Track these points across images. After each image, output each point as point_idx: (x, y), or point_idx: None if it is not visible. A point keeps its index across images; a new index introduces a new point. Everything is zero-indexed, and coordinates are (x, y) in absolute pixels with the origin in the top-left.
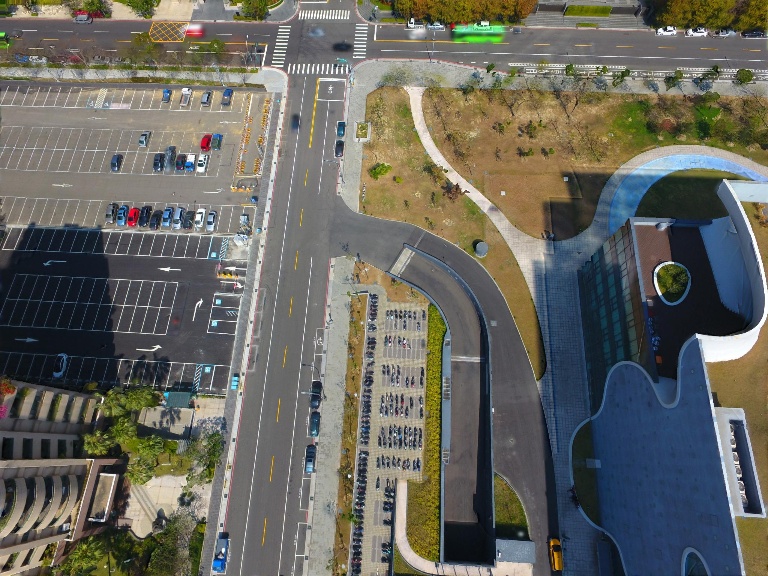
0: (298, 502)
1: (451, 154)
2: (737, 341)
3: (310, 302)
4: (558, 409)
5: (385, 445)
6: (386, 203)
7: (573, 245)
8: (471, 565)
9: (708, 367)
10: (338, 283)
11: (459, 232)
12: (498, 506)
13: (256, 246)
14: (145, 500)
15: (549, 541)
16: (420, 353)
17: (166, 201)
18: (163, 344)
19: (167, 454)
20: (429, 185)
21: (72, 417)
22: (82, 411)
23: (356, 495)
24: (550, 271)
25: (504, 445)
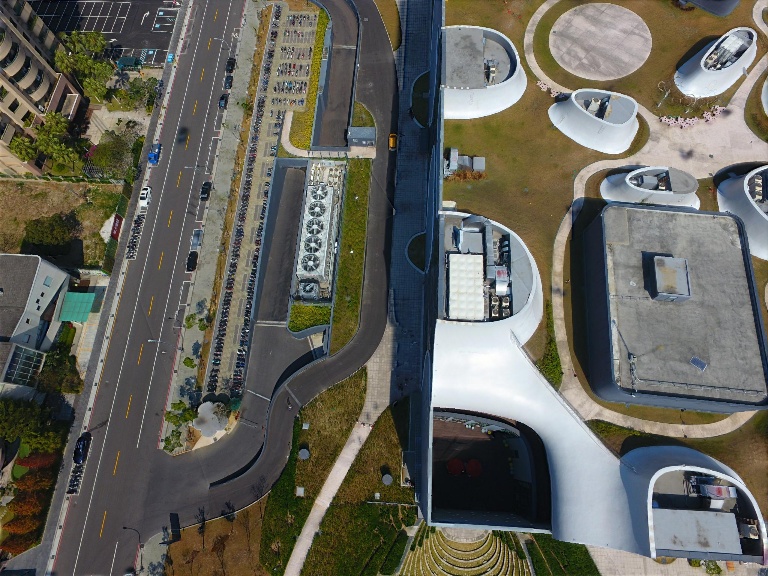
0: (213, 126)
1: None
2: None
3: (231, 12)
4: (407, 66)
5: (278, 90)
6: None
7: None
8: (331, 147)
9: None
10: None
11: None
12: (356, 119)
13: None
14: (101, 125)
15: (389, 135)
16: (310, 40)
17: None
18: (118, 38)
19: (118, 98)
20: None
21: (46, 41)
22: (54, 49)
23: (255, 118)
24: None
25: (365, 87)
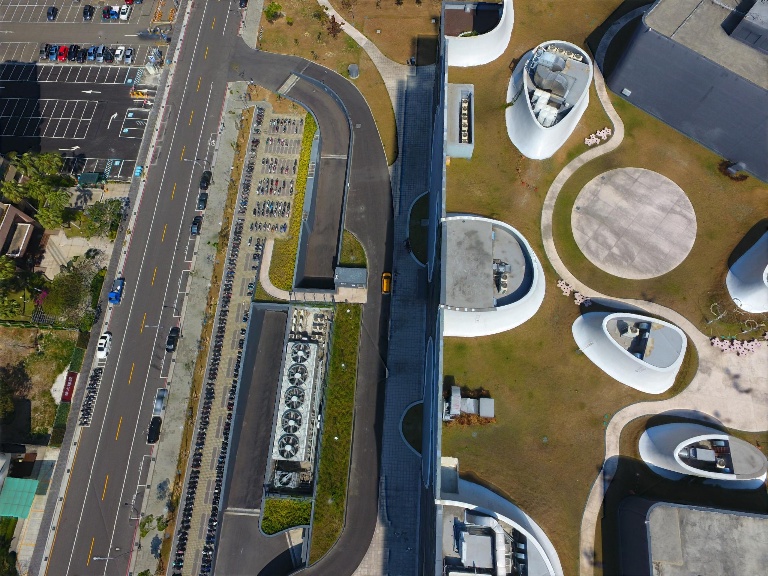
0: (184, 256)
1: (339, 4)
2: (479, 44)
3: (208, 114)
4: (403, 185)
5: (258, 213)
6: (279, 41)
7: (433, 69)
8: (316, 290)
9: (462, 71)
10: (232, 100)
11: (338, 61)
12: (345, 252)
13: (166, 74)
14: (58, 254)
15: (382, 274)
16: (295, 149)
17: (93, 42)
18: (81, 145)
19: (78, 221)
20: (317, 27)
21: None
22: (3, 173)
23: (230, 248)
24: (410, 88)
25: (355, 211)
